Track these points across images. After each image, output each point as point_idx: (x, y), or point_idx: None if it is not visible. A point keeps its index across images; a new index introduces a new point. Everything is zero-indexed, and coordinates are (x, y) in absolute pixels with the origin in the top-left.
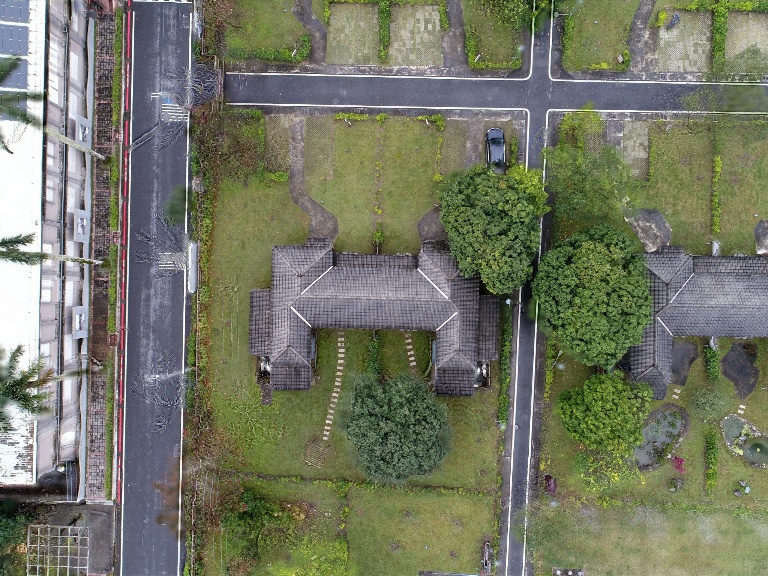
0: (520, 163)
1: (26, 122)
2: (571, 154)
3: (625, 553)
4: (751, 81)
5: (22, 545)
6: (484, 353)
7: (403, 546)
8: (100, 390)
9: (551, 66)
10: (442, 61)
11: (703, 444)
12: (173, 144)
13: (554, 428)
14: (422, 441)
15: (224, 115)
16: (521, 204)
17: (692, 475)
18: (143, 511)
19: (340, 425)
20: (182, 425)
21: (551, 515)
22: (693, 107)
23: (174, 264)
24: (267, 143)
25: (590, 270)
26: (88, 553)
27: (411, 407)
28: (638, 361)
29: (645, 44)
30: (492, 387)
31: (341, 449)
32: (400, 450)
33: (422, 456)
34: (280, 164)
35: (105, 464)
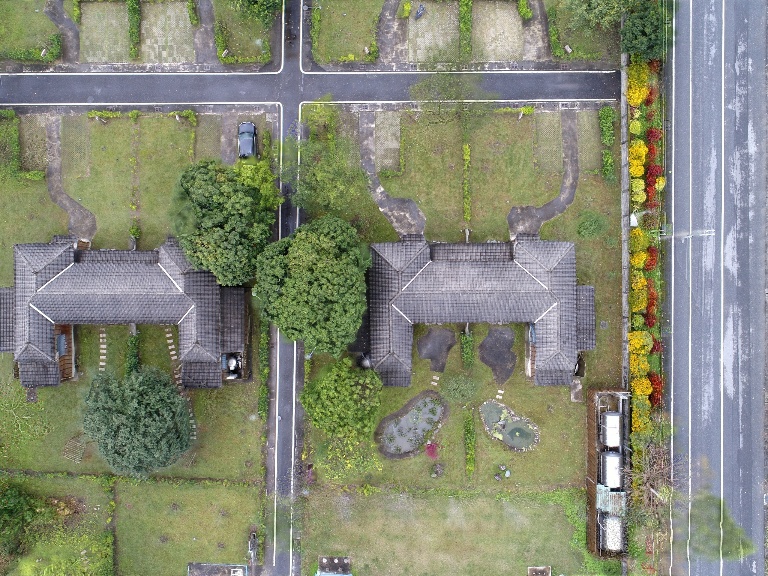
0: (275, 156)
1: None
2: (323, 146)
3: (390, 539)
4: (500, 69)
5: None
6: (229, 345)
7: (172, 538)
8: None
9: (302, 59)
10: (195, 57)
11: (463, 430)
12: None
13: None
14: (151, 433)
15: None
16: (236, 196)
17: (453, 461)
18: None
19: None
20: None
21: (316, 504)
22: (443, 96)
23: None
24: (24, 143)
25: (297, 260)
26: None
27: (143, 400)
28: (377, 349)
29: (394, 35)
30: (254, 379)
31: None
32: (131, 443)
33: (152, 448)
34: (37, 163)
35: None
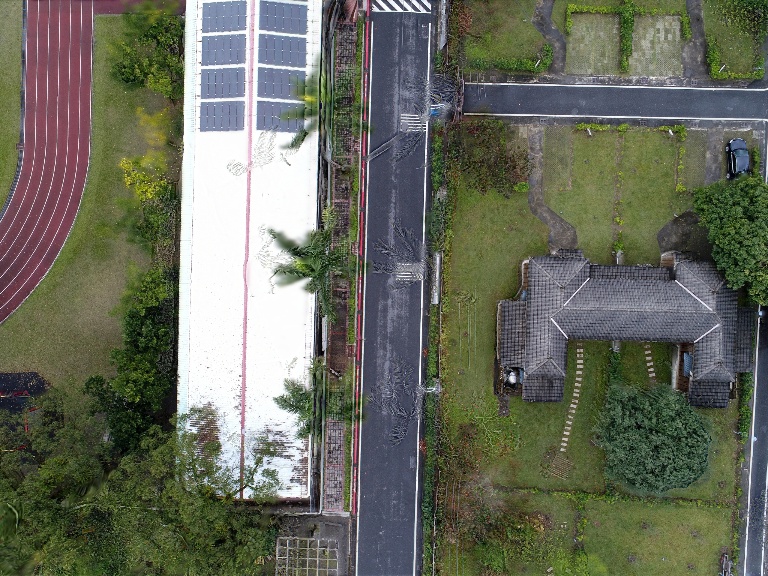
0: (760, 173)
1: (304, 134)
2: None
3: None
4: None
5: (259, 557)
6: (739, 365)
7: (640, 558)
8: (338, 401)
9: None
10: (682, 71)
11: None
12: (411, 154)
13: None
14: (696, 454)
15: (464, 125)
16: None
17: None
18: (379, 523)
19: (578, 436)
20: (418, 436)
21: None
22: None
23: (411, 275)
24: None
25: None
26: (337, 565)
27: (681, 420)
28: None
29: None
30: None
31: (578, 460)
32: (672, 463)
33: (695, 469)
34: (519, 174)
35: (343, 475)
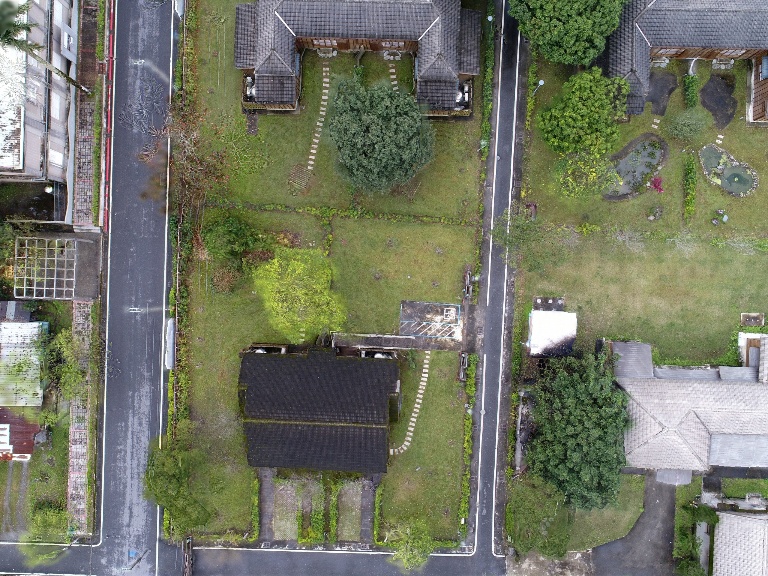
0: None
1: None
2: None
3: (605, 282)
4: None
5: (10, 270)
6: (465, 66)
7: (386, 276)
8: (88, 117)
9: None
10: None
11: (682, 173)
12: None
13: (535, 158)
14: (403, 131)
15: None
16: None
17: (671, 204)
18: (130, 239)
19: (324, 154)
20: (169, 154)
21: (532, 244)
22: None
23: None
24: None
25: None
26: None
27: (392, 101)
28: (616, 69)
29: None
30: (474, 117)
31: (325, 179)
32: (381, 141)
33: (403, 147)
34: None
35: (93, 190)
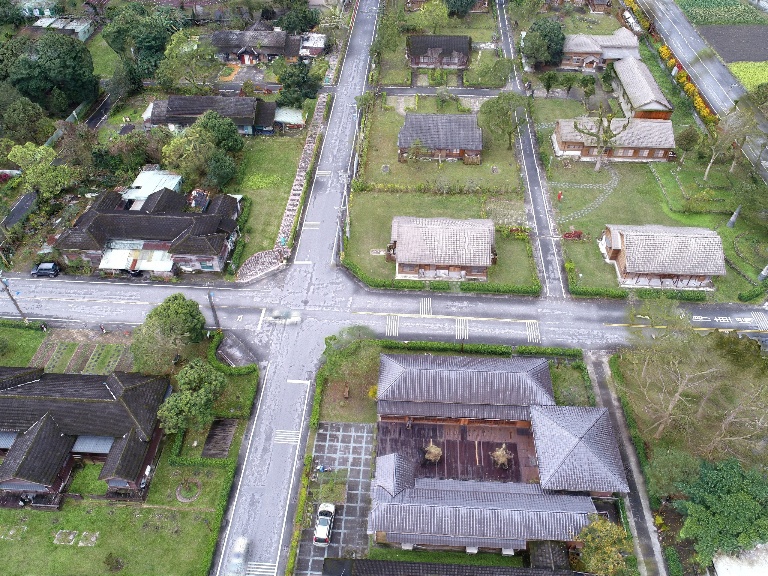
0: None
1: None
2: None
3: None
4: None
5: None
6: None
7: None
8: None
9: None
10: None
11: None
12: None
13: None
14: None
15: None
16: None
17: None
18: None
19: None
20: None
21: None
22: None
23: None
24: None
25: None
26: None
27: None
28: None
29: None
30: None
31: None
32: None
33: None
34: None
35: None
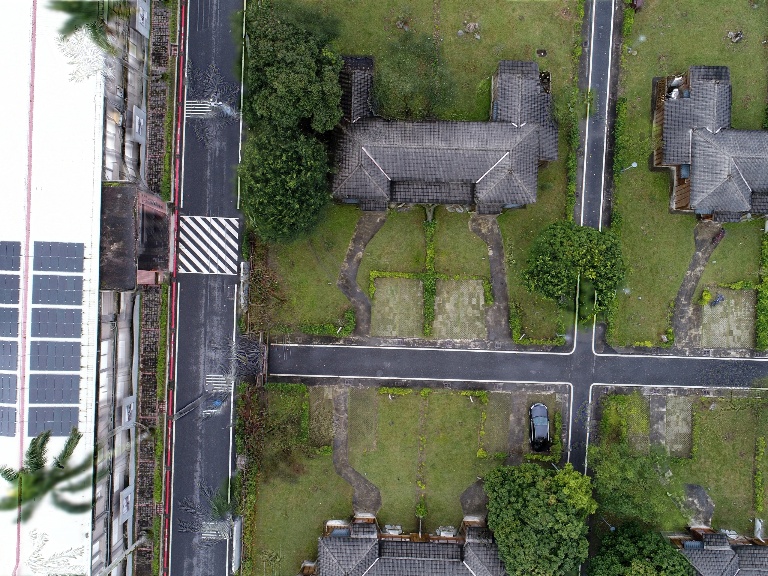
0: (563, 436)
1: (78, 437)
2: (614, 430)
3: None
4: None
5: None
6: None
7: None
8: None
9: (595, 341)
10: (486, 334)
11: None
12: (217, 414)
13: None
14: None
15: (268, 387)
16: (571, 524)
17: None
18: None
19: None
20: None
21: None
22: (736, 383)
23: (217, 533)
24: (311, 414)
25: None
26: None
27: None
28: None
29: (689, 320)
30: None
31: None
32: None
33: None
34: (323, 435)
35: None
